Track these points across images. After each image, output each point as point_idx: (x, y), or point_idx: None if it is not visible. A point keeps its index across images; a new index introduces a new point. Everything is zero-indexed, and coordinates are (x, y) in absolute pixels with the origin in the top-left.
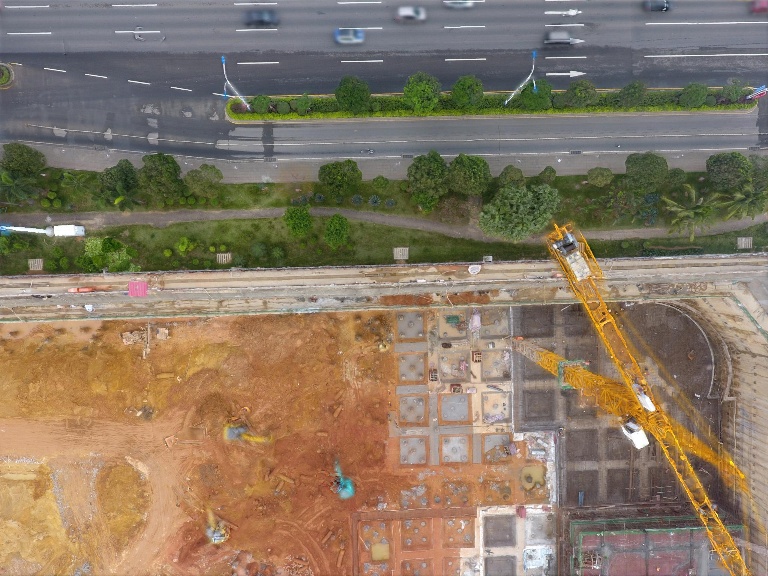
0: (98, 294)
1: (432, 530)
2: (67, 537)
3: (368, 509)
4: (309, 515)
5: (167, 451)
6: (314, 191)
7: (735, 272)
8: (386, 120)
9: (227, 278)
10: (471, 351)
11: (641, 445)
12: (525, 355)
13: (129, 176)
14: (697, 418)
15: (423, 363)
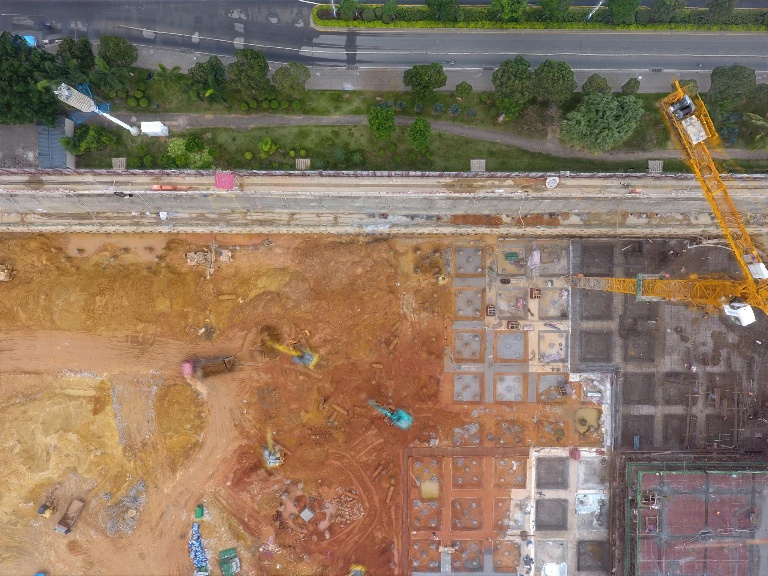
0: (178, 195)
1: (483, 469)
2: (123, 455)
3: (420, 444)
4: (361, 447)
5: (226, 372)
6: (394, 100)
7: None
8: (468, 32)
9: (305, 183)
10: (529, 288)
11: (747, 321)
12: (589, 287)
13: (218, 73)
14: (758, 365)
15: (480, 299)
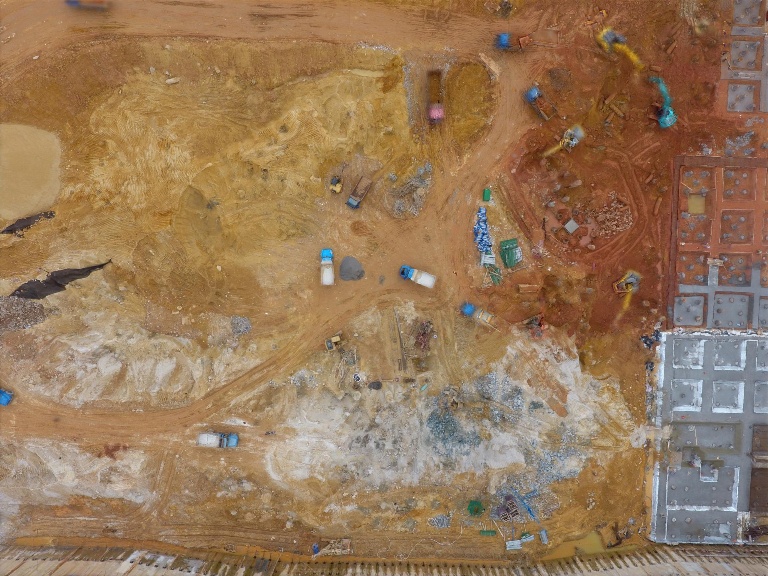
0: None
1: (756, 180)
2: (411, 136)
3: (693, 153)
4: (638, 149)
5: (520, 52)
6: None
7: None
8: None
9: None
10: None
11: None
12: None
13: None
14: None
15: (758, 7)
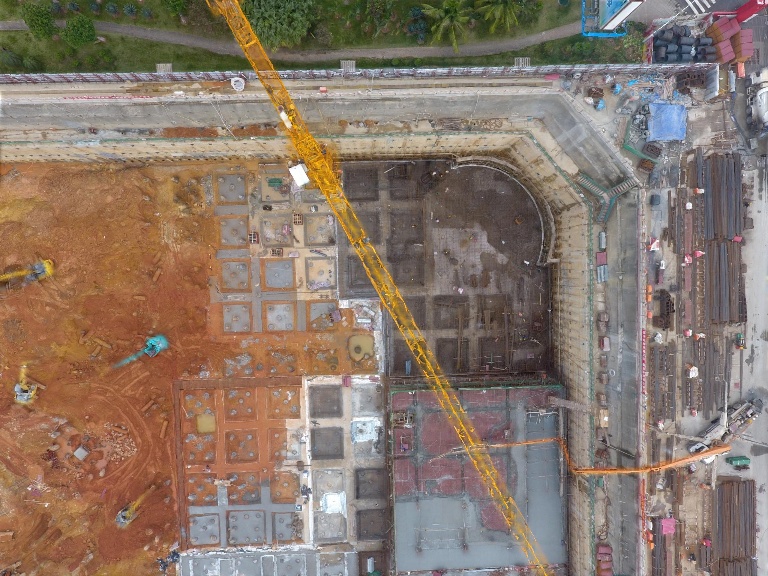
0: None
1: (256, 400)
2: None
3: (190, 377)
4: (126, 380)
5: None
6: None
7: None
8: None
9: None
10: None
11: (300, 181)
12: None
13: None
14: (527, 286)
15: (246, 227)
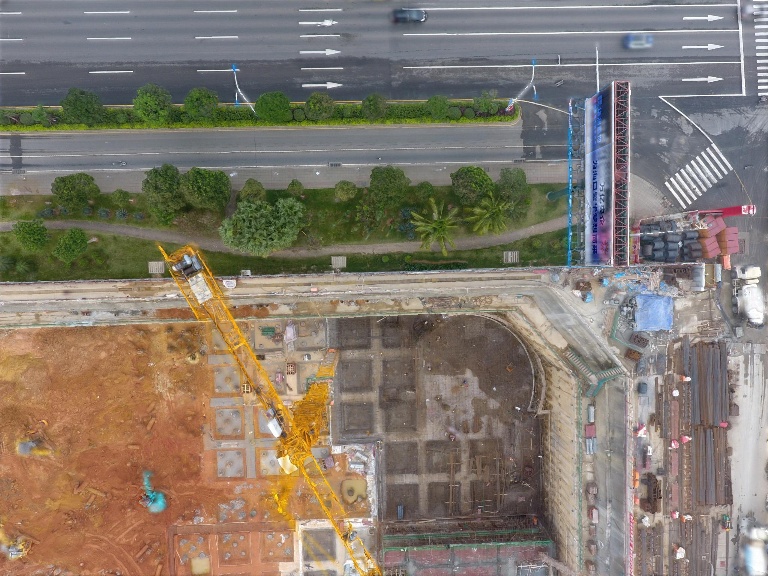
0: None
1: (250, 544)
2: None
3: (184, 523)
4: (120, 529)
5: None
6: None
7: (496, 287)
8: (138, 132)
9: None
10: (286, 363)
11: (288, 470)
12: None
13: None
14: (518, 431)
15: (239, 375)
